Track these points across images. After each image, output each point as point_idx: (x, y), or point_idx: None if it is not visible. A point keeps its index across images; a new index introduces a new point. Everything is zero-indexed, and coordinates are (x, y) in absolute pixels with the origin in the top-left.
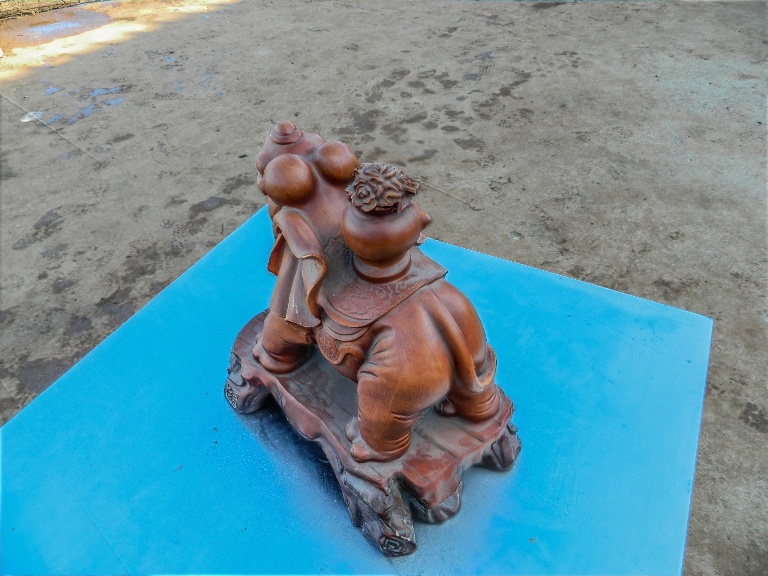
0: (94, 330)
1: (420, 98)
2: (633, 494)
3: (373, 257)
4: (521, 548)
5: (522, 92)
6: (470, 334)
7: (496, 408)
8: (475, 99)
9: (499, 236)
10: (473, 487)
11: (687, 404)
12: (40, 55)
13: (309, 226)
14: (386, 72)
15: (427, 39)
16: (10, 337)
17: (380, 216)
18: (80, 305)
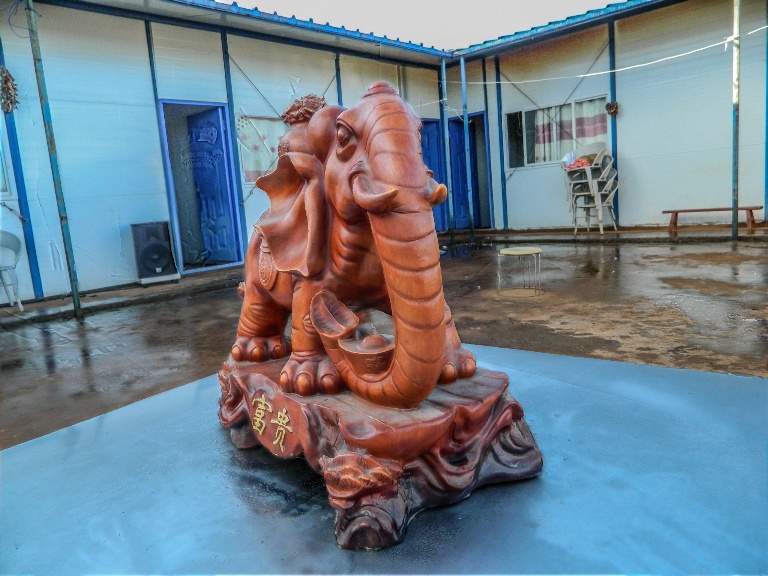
0: None
1: None
2: None
3: None
4: None
5: None
6: None
7: None
8: None
9: None
10: None
11: None
12: None
13: None
14: None
15: None
16: None
17: None
18: None
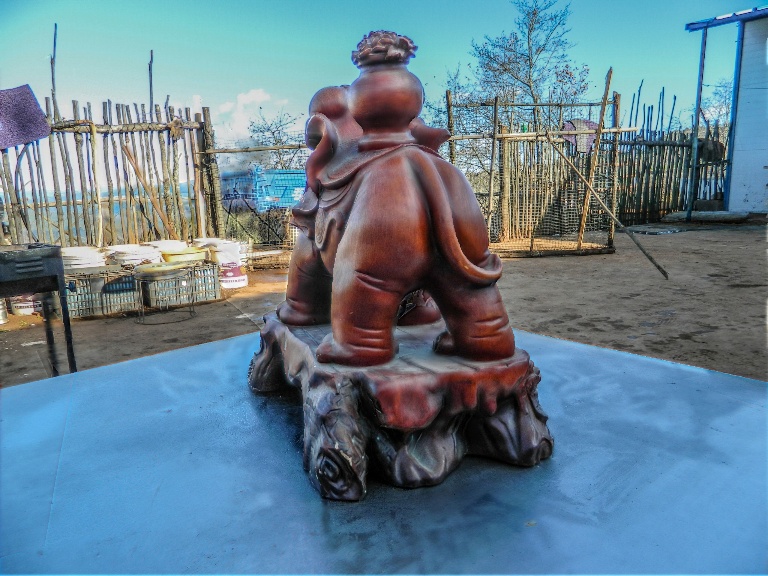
0: None
1: (587, 333)
2: (718, 518)
3: (364, 106)
4: (509, 527)
5: (706, 338)
6: (457, 196)
7: (506, 347)
8: (648, 338)
9: None
10: (472, 471)
11: None
12: (272, 287)
13: None
14: (557, 315)
15: (606, 299)
16: None
17: (374, 64)
18: None
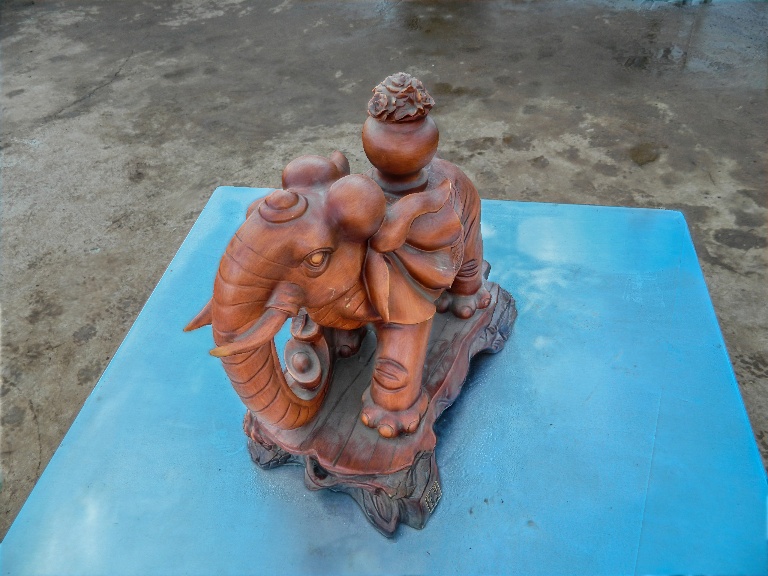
0: None
1: None
2: None
3: None
4: None
5: None
6: None
7: None
8: None
9: None
10: None
11: None
12: None
13: None
14: None
15: None
16: None
17: None
18: None
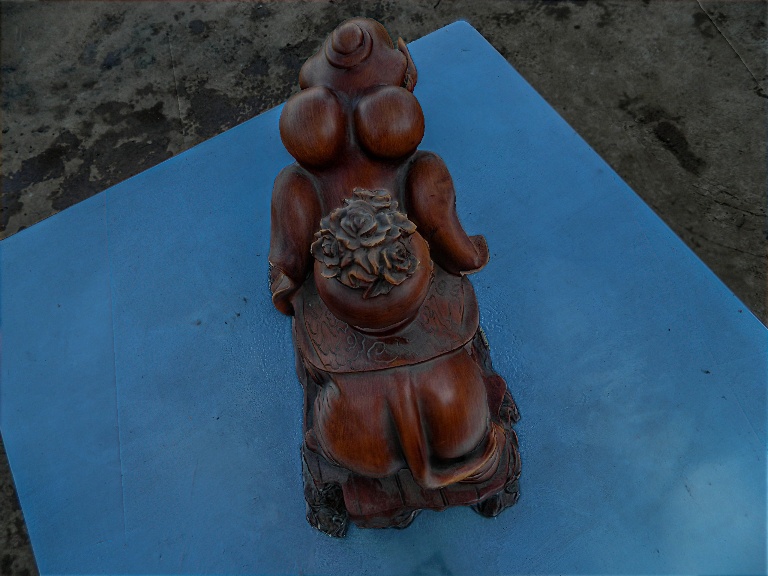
0: (268, 78)
1: None
2: None
3: None
4: None
5: None
6: (443, 440)
7: (484, 479)
8: None
9: (765, 147)
10: None
11: (766, 575)
12: None
13: (305, 211)
14: None
15: None
16: (199, 54)
17: None
18: (267, 44)
